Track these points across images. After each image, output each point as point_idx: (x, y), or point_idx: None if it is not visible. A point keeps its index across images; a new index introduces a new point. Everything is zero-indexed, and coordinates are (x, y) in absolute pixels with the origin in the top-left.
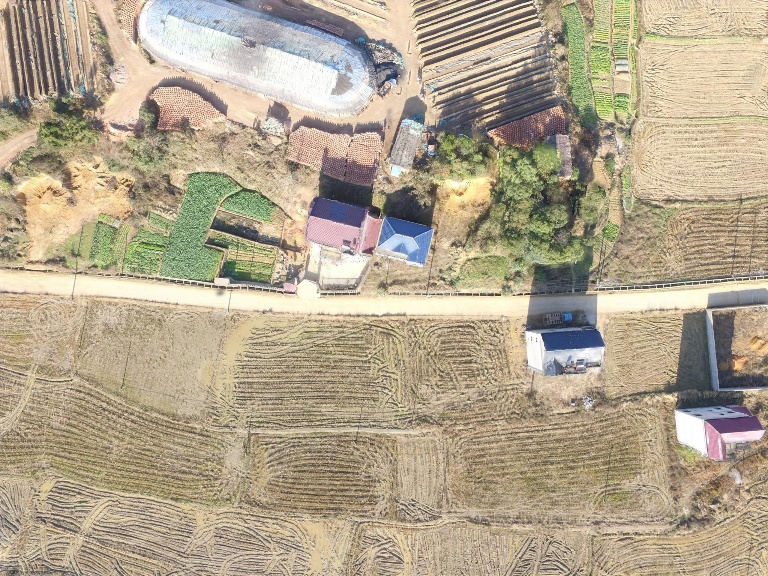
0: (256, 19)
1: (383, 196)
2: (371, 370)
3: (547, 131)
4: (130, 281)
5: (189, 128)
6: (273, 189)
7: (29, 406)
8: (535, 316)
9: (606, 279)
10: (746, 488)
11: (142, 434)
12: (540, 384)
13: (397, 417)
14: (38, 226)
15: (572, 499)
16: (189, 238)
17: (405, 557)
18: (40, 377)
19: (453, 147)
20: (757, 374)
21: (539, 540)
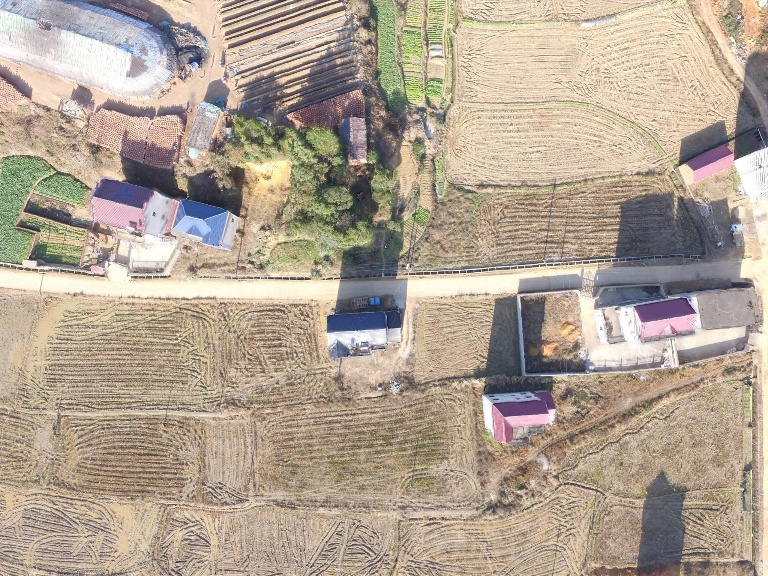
0: (55, 2)
1: (184, 179)
2: (181, 353)
3: (346, 114)
4: None
5: None
6: (82, 172)
7: None
8: (345, 300)
9: (417, 264)
10: (554, 474)
11: None
12: (348, 368)
13: (206, 400)
14: None
15: (379, 483)
16: (2, 221)
17: (212, 540)
18: None
19: (242, 129)
20: (566, 360)
21: (346, 524)
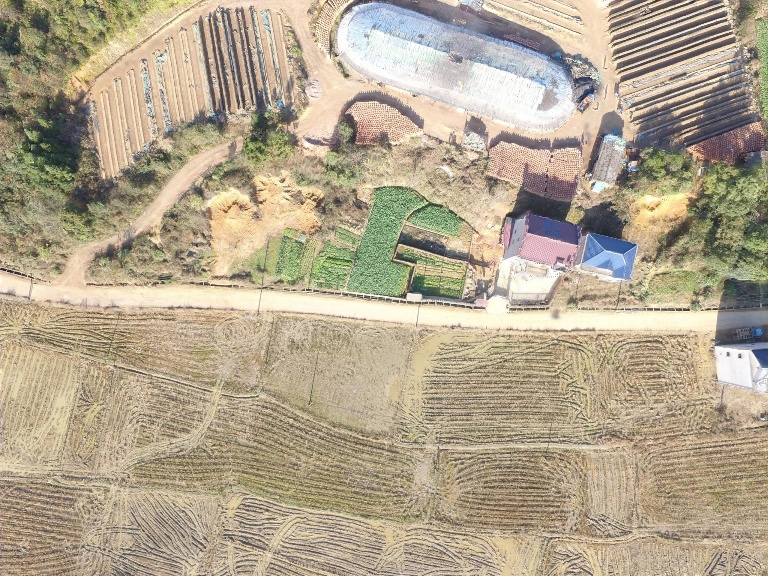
0: (459, 34)
1: (582, 212)
2: (560, 385)
3: (747, 147)
4: (317, 296)
5: (387, 143)
6: (464, 204)
7: (215, 422)
8: (723, 331)
9: None
10: None
11: (330, 450)
12: (729, 399)
13: (587, 432)
14: (223, 241)
15: (761, 513)
16: (377, 253)
17: (595, 572)
18: (226, 393)
19: (664, 164)
20: None
21: (728, 554)
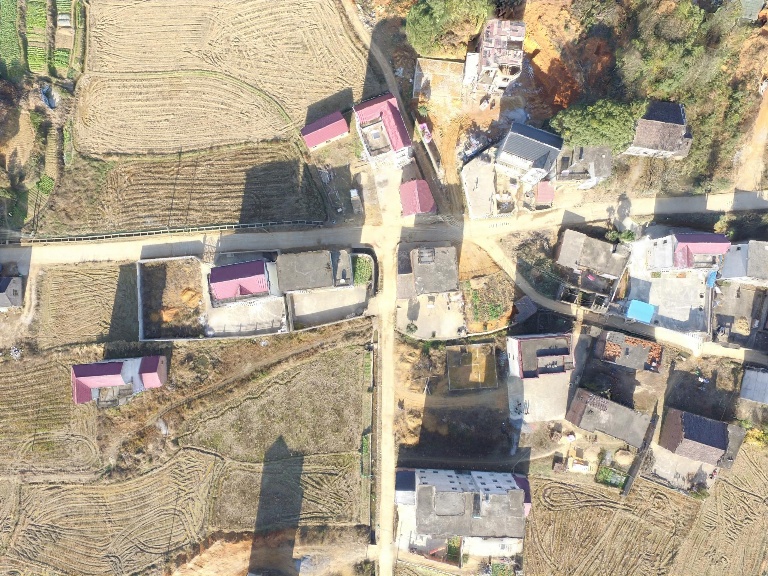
0: None
1: None
2: None
3: None
4: None
5: None
6: None
7: None
8: None
9: (41, 231)
10: (172, 438)
11: None
12: None
13: None
14: None
15: (1, 448)
16: None
17: None
18: None
19: None
20: (186, 325)
21: None
